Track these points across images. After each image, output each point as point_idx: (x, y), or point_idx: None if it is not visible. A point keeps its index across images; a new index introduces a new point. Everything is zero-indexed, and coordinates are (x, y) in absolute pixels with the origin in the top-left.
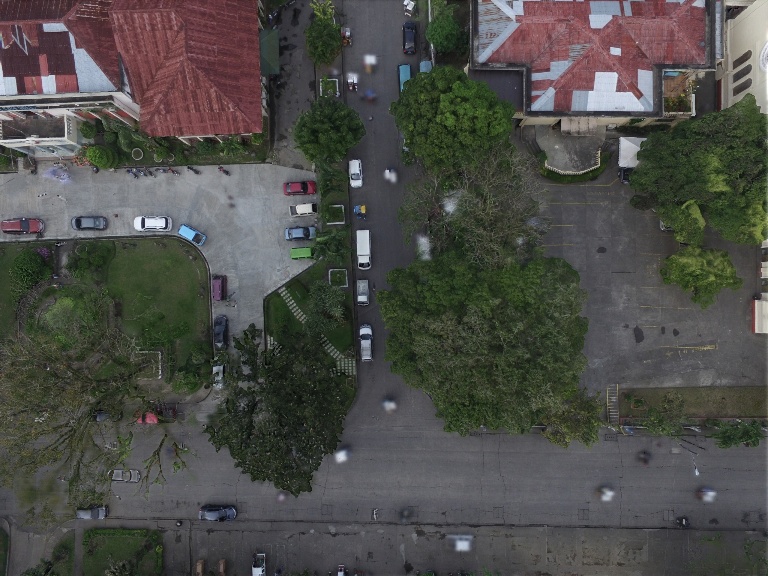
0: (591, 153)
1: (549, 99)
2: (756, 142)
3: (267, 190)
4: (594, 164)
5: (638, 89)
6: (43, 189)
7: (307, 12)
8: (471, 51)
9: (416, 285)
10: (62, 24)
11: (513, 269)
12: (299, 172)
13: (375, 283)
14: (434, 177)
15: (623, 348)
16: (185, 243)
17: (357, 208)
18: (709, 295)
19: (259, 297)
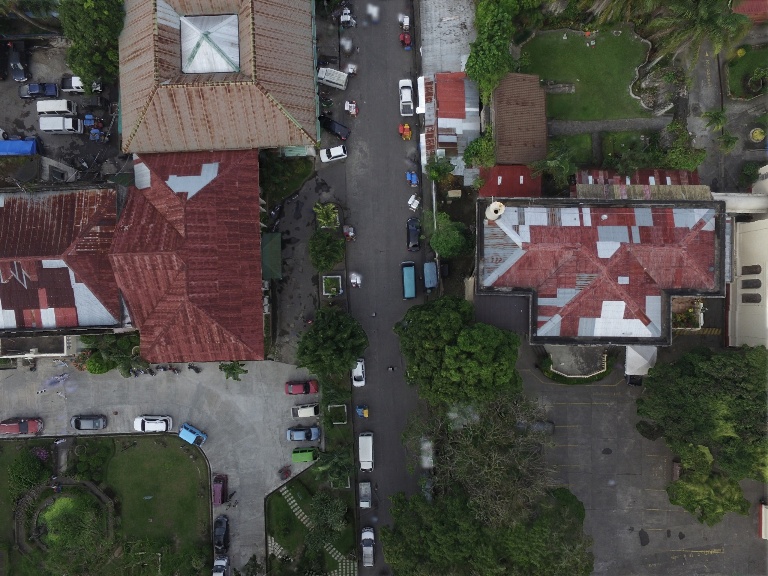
0: (597, 355)
1: (555, 325)
2: (766, 391)
3: (269, 387)
4: (600, 367)
5: (646, 316)
6: (42, 385)
7: (310, 205)
8: (476, 277)
9: (419, 531)
10: (62, 260)
11: (518, 530)
12: (301, 369)
13: (377, 483)
14: (438, 417)
15: (628, 551)
16: (185, 441)
17: (360, 411)
18: (716, 515)
19: (260, 496)
